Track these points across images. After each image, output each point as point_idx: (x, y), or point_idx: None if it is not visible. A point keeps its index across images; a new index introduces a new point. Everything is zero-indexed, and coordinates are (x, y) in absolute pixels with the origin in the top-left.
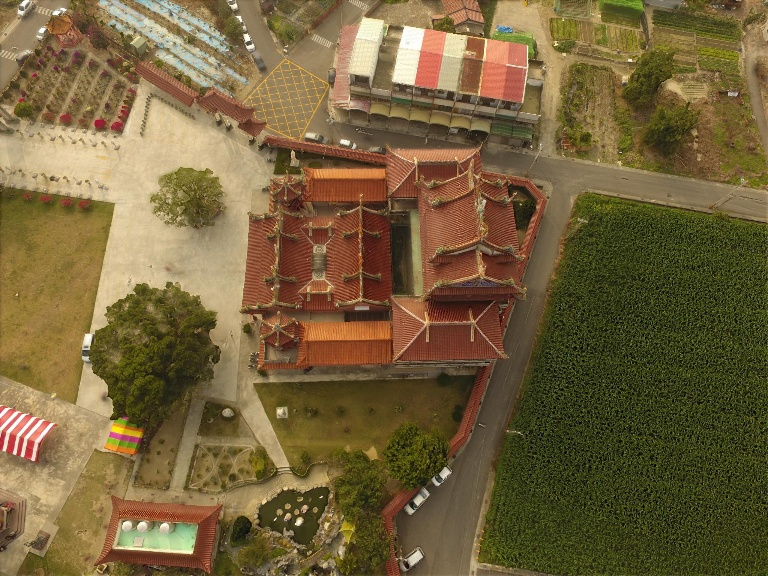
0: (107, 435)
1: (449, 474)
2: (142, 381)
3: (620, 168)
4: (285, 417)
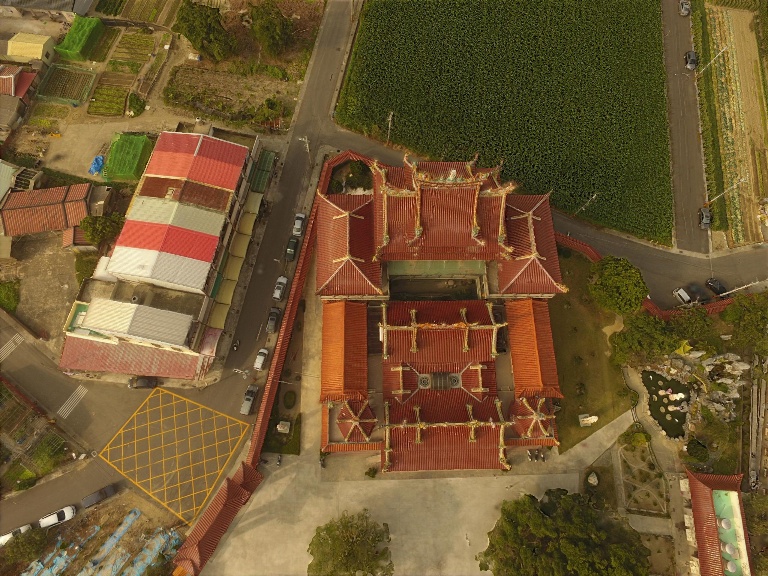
0: None
1: None
2: (620, 569)
3: (306, 83)
4: None
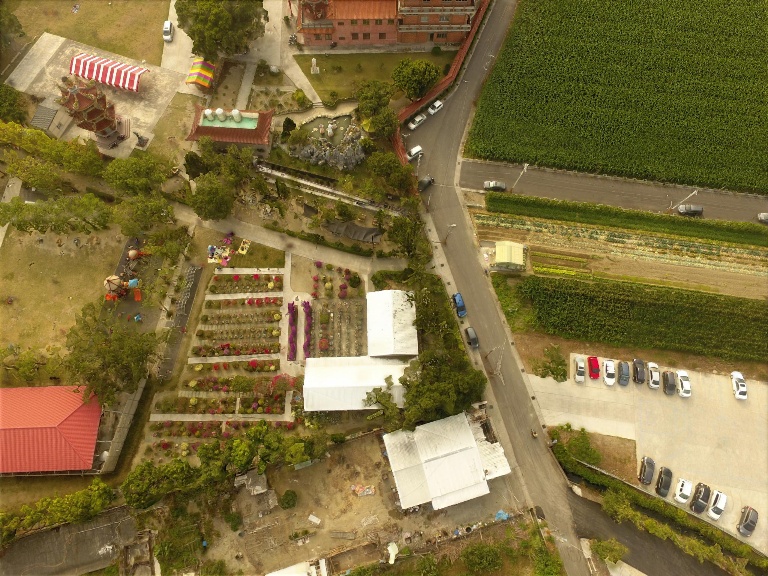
0: (185, 84)
1: (441, 105)
2: (217, 10)
3: None
4: (317, 73)
